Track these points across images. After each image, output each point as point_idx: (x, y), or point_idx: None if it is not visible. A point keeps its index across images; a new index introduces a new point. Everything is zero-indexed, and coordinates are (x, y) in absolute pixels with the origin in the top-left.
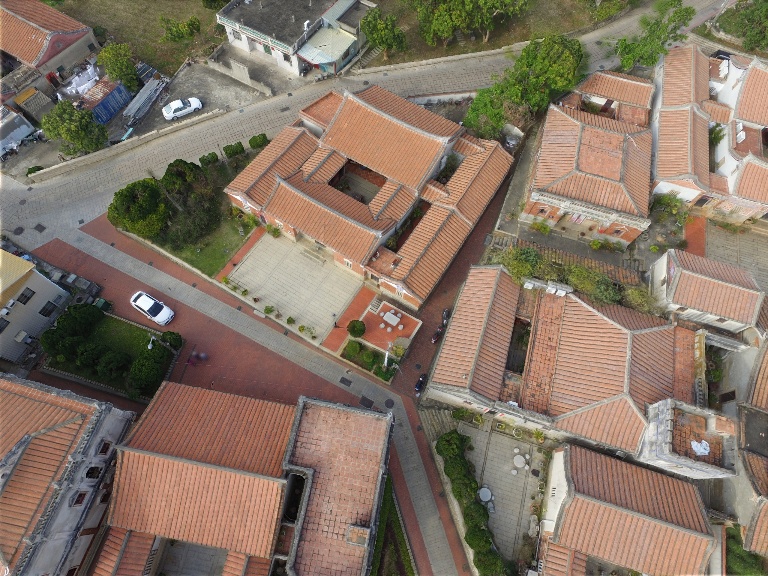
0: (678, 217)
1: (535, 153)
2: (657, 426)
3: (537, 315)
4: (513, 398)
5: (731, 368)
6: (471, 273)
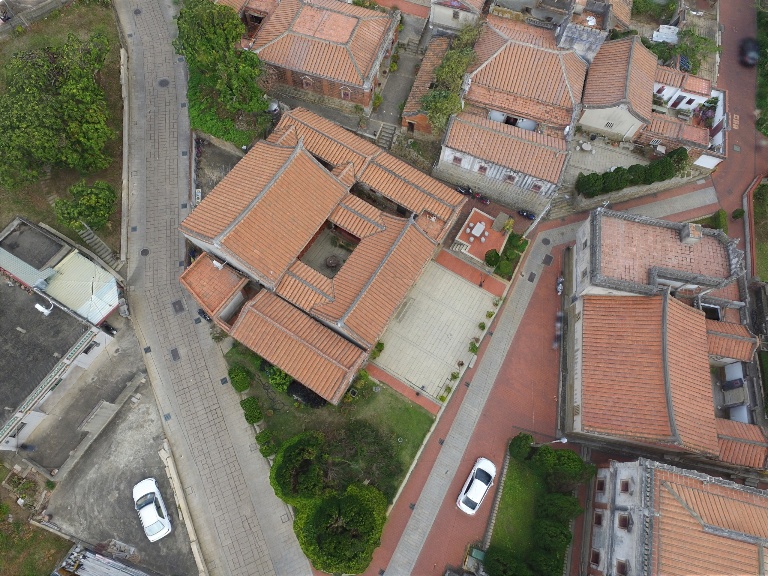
0: (372, 3)
1: (295, 88)
2: (581, 40)
3: (488, 104)
4: (558, 132)
5: (507, 6)
6: (452, 145)
